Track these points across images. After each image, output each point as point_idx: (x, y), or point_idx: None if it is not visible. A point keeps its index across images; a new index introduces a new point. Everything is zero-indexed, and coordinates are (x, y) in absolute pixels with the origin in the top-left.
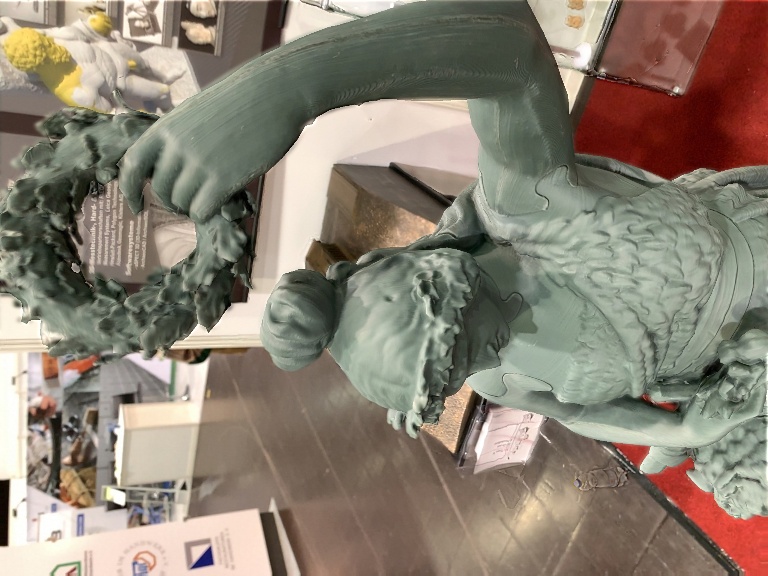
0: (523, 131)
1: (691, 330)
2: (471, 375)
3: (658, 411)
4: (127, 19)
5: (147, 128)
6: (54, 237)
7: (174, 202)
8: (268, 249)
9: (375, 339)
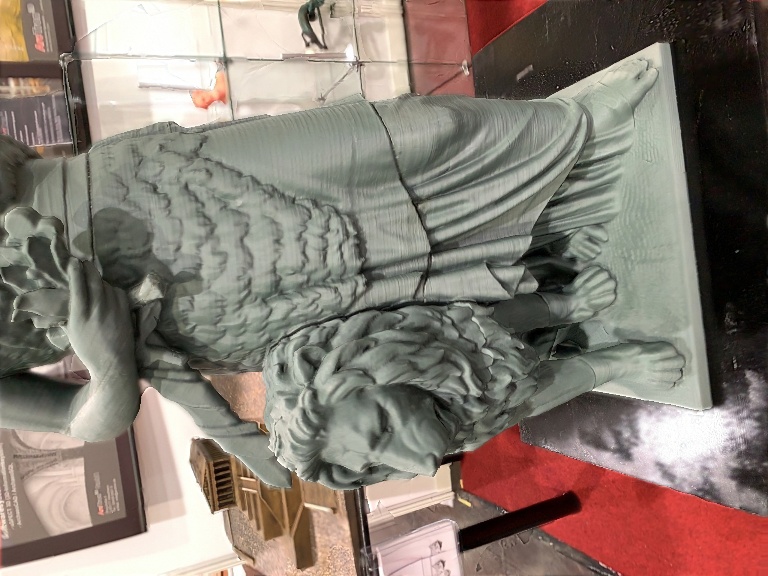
0: None
1: None
2: None
3: None
4: None
5: None
6: None
7: None
8: (163, 468)
9: None
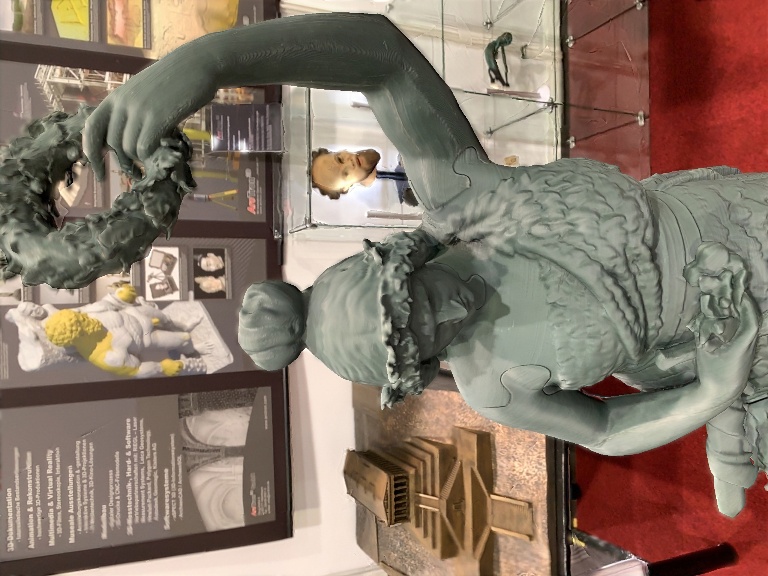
0: (418, 111)
1: (652, 269)
2: (472, 392)
3: (678, 388)
4: (149, 285)
5: None
6: (34, 200)
7: (125, 150)
8: (306, 475)
9: (337, 300)
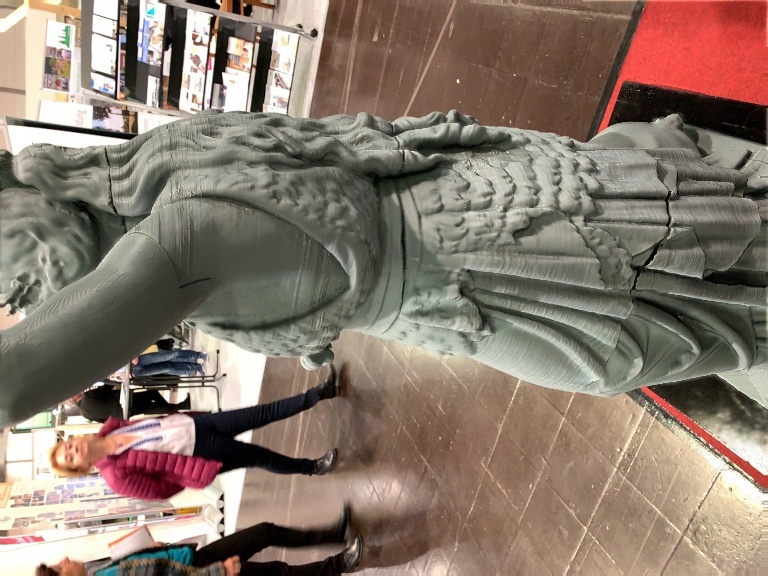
0: None
1: None
2: None
3: None
4: None
5: None
6: None
7: None
8: None
9: None
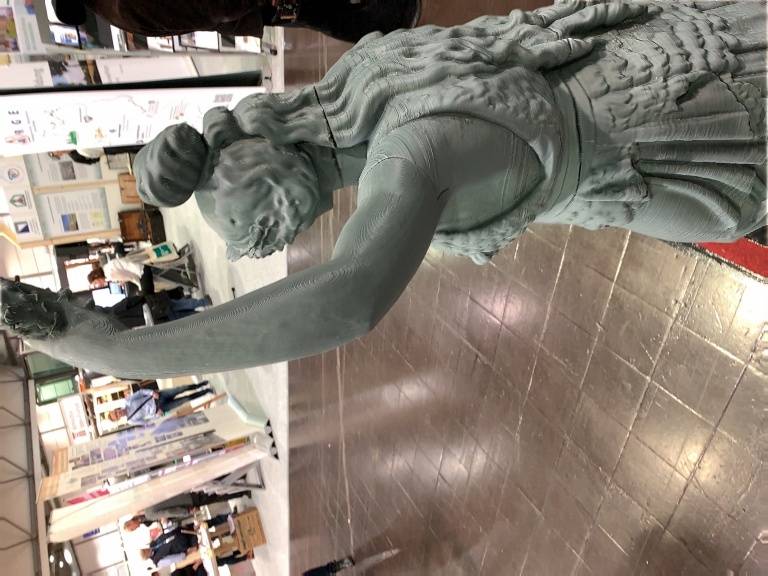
0: None
1: None
2: None
3: None
4: None
5: (37, 334)
6: None
7: None
8: None
9: None
